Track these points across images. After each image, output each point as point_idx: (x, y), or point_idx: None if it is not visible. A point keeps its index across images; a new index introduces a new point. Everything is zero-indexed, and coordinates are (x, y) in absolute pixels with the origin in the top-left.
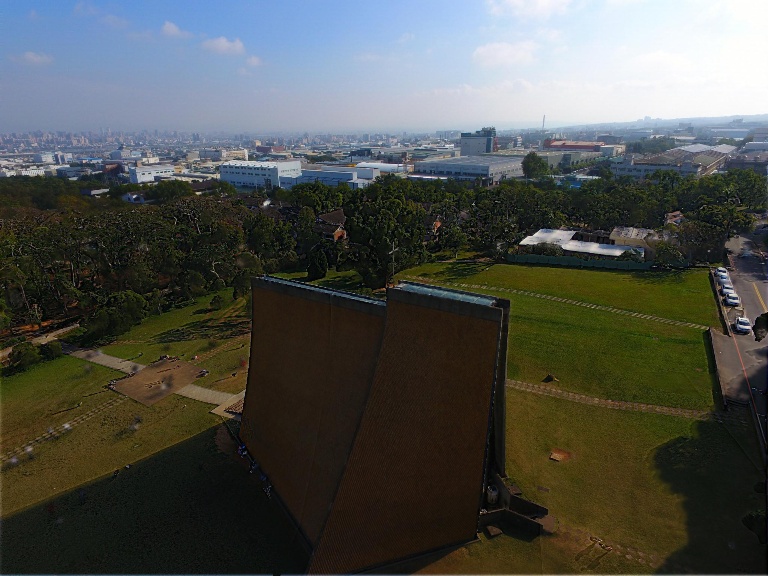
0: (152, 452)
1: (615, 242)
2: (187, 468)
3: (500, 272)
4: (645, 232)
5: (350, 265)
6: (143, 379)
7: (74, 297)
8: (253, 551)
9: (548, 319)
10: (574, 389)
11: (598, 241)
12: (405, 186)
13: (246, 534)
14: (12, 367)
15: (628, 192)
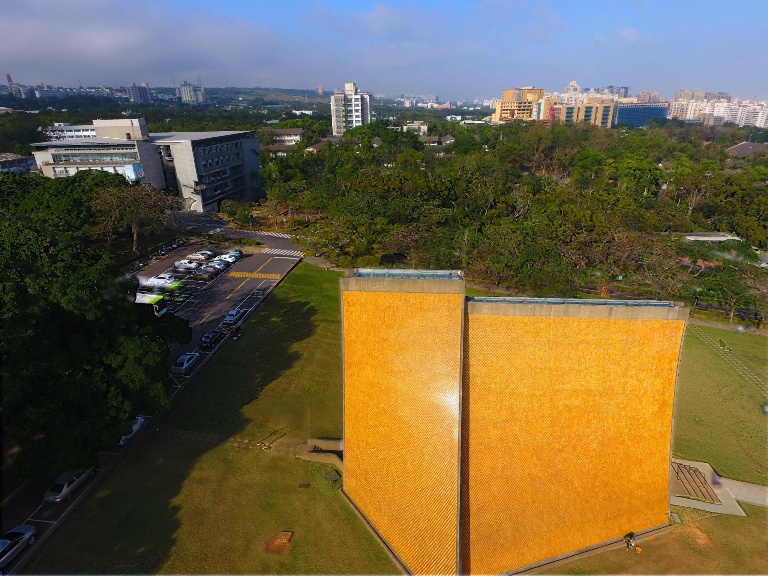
0: None
1: None
2: None
3: None
4: None
5: None
6: None
7: None
8: None
9: None
10: None
11: None
12: None
13: None
14: None
15: None
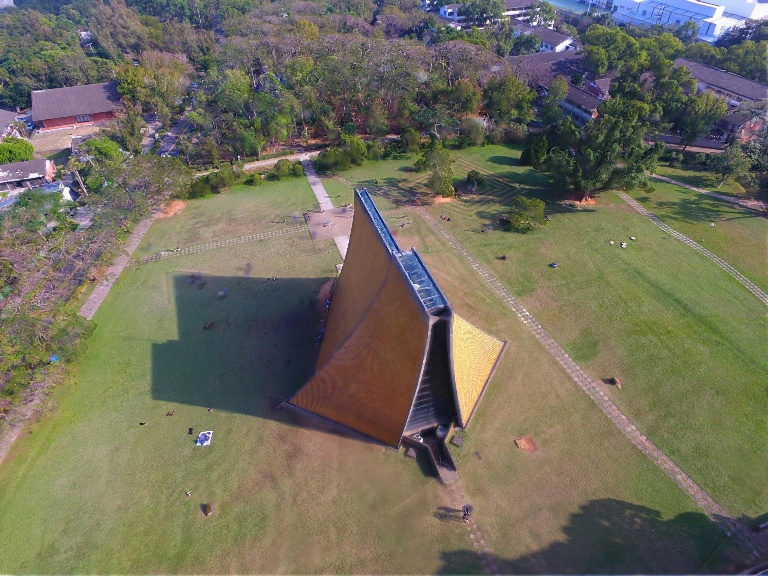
0: (290, 276)
1: None
2: (296, 298)
3: (747, 231)
4: None
5: (547, 167)
6: (325, 218)
7: (326, 130)
8: (285, 368)
9: (710, 321)
10: (624, 405)
11: None
12: (761, 50)
13: (290, 356)
14: (274, 175)
15: None
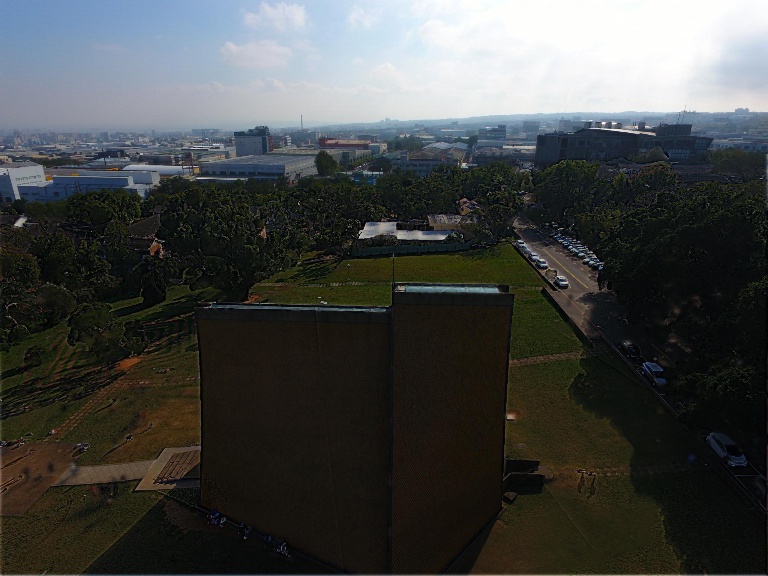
0: (80, 570)
1: (434, 228)
2: (154, 568)
3: (353, 267)
4: (452, 217)
5: (208, 281)
6: None
7: None
8: None
9: None
10: None
11: (415, 229)
12: None
13: None
14: None
15: (430, 184)
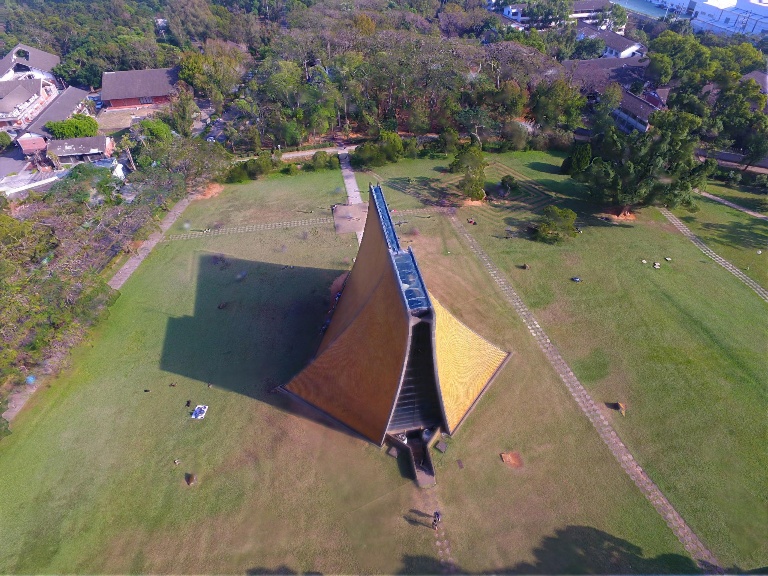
0: (307, 266)
1: None
2: (309, 287)
3: None
4: None
5: (585, 177)
6: (352, 212)
7: None
8: (286, 353)
9: (738, 355)
10: (624, 432)
11: None
12: None
13: (292, 343)
14: (310, 166)
15: None
